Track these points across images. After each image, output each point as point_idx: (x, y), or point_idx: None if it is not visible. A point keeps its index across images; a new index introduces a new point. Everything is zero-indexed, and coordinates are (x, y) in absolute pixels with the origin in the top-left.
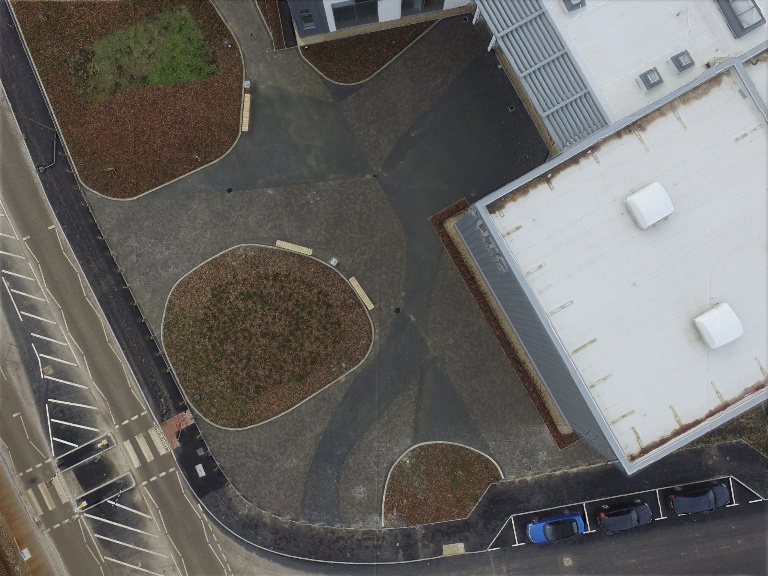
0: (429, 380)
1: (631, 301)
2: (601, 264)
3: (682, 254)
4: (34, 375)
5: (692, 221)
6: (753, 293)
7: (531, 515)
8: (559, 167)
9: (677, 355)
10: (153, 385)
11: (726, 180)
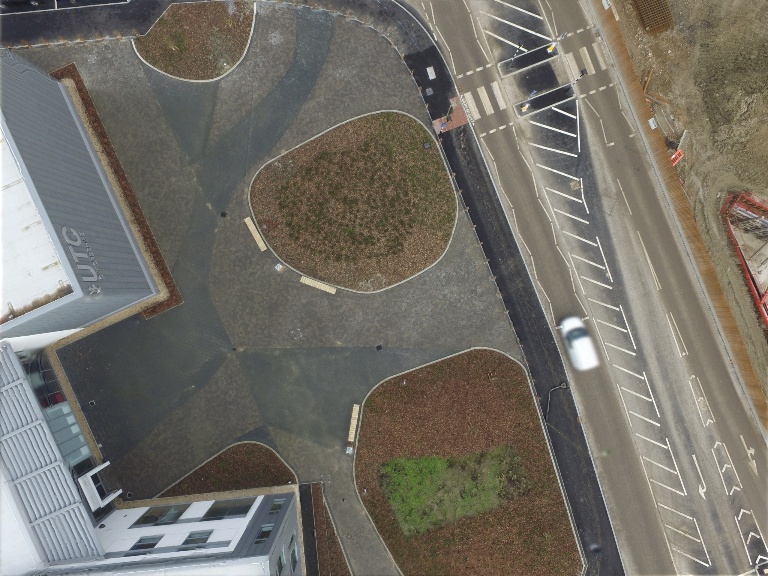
0: (198, 143)
1: None
2: None
3: None
4: (589, 182)
5: None
6: None
7: (109, 2)
8: (1, 324)
9: None
10: (471, 162)
11: None
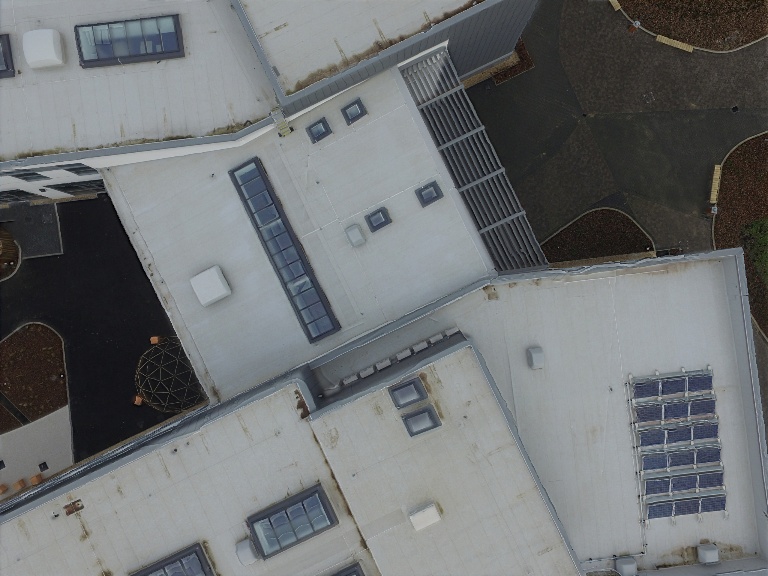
0: None
1: None
2: None
3: None
4: None
5: None
6: None
7: None
8: None
9: None
10: None
11: None
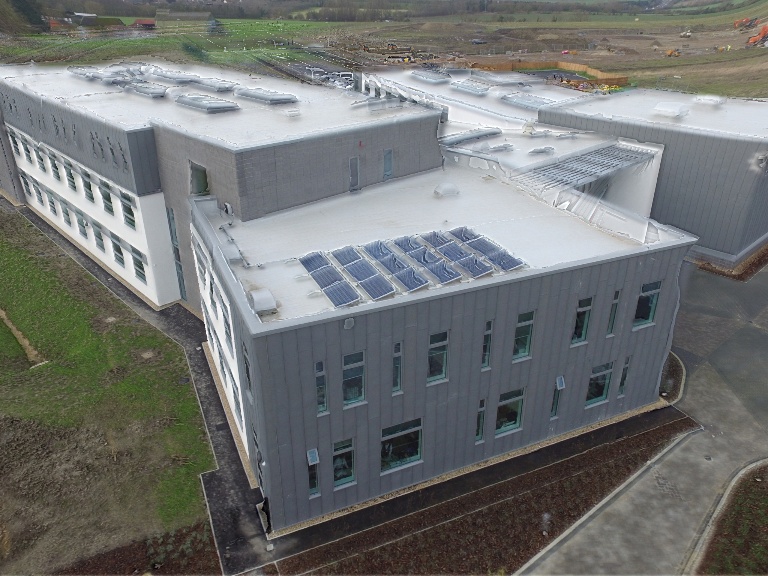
0: None
1: None
2: (731, 119)
3: None
4: None
5: None
6: None
7: None
8: None
9: (745, 106)
10: None
11: (619, 105)
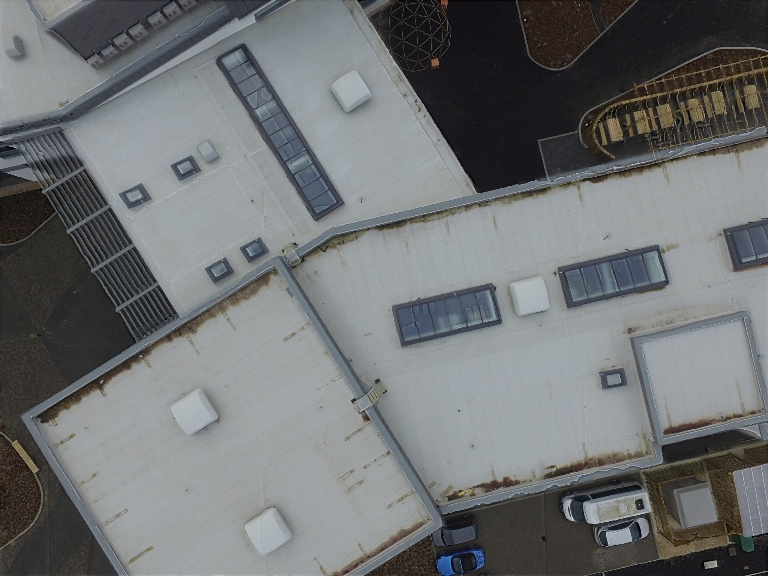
0: None
1: (185, 507)
2: (155, 470)
3: (235, 457)
4: None
5: (244, 423)
6: (308, 493)
7: None
8: (111, 373)
9: (236, 559)
10: None
11: (276, 380)
